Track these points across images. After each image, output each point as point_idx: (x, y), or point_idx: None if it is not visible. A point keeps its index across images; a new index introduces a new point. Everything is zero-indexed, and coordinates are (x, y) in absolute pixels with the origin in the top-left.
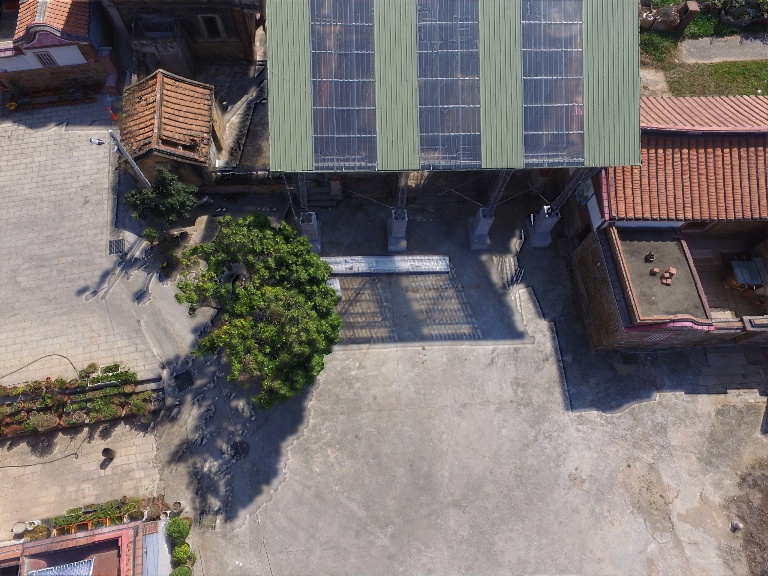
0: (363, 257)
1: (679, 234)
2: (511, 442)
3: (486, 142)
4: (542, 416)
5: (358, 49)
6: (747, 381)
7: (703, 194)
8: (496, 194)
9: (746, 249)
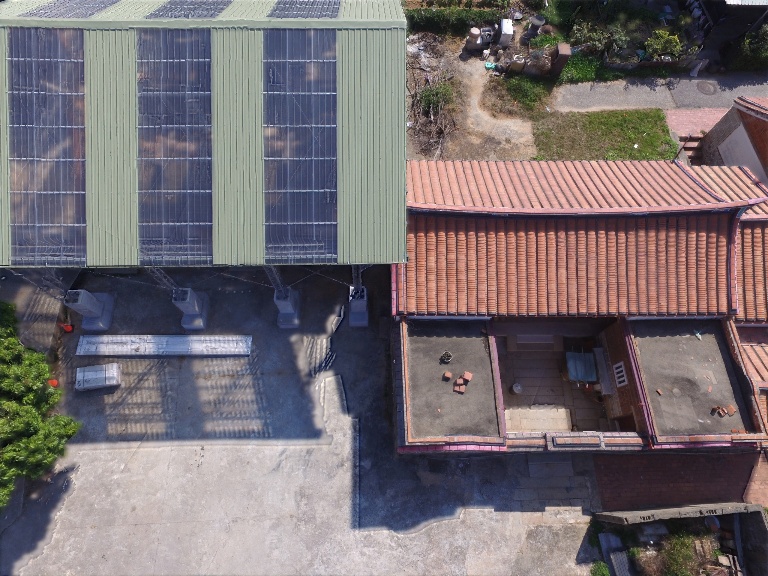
0: (153, 336)
1: (488, 328)
2: (281, 567)
3: (218, 234)
4: (323, 535)
5: (65, 123)
6: (570, 496)
7: (511, 285)
8: (272, 280)
9: (592, 334)
